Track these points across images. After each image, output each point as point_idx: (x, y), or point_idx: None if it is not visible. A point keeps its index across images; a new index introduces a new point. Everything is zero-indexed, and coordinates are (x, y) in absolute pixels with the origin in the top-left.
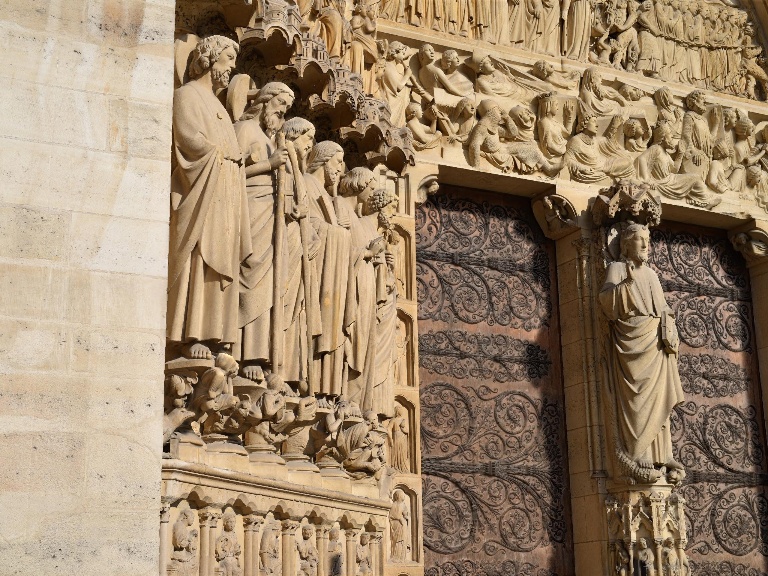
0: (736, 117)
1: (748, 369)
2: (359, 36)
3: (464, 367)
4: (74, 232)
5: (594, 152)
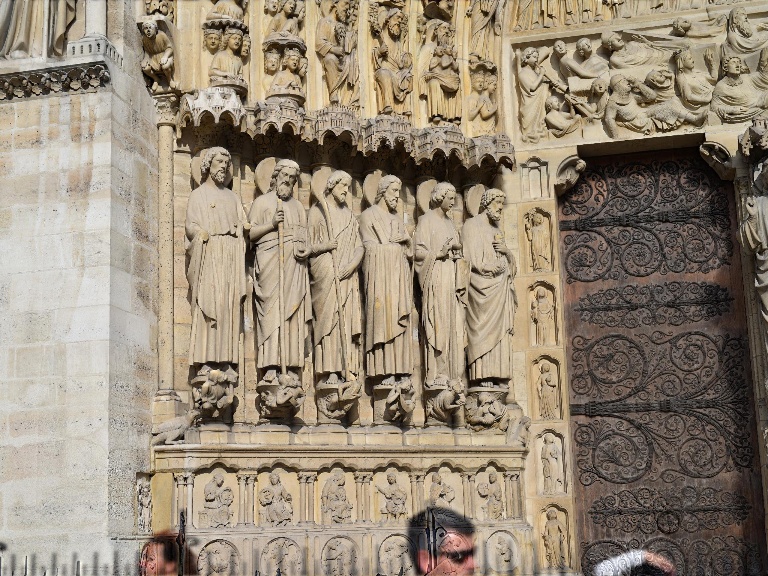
0: None
1: None
2: (435, 74)
3: (636, 317)
4: (57, 322)
5: (742, 91)
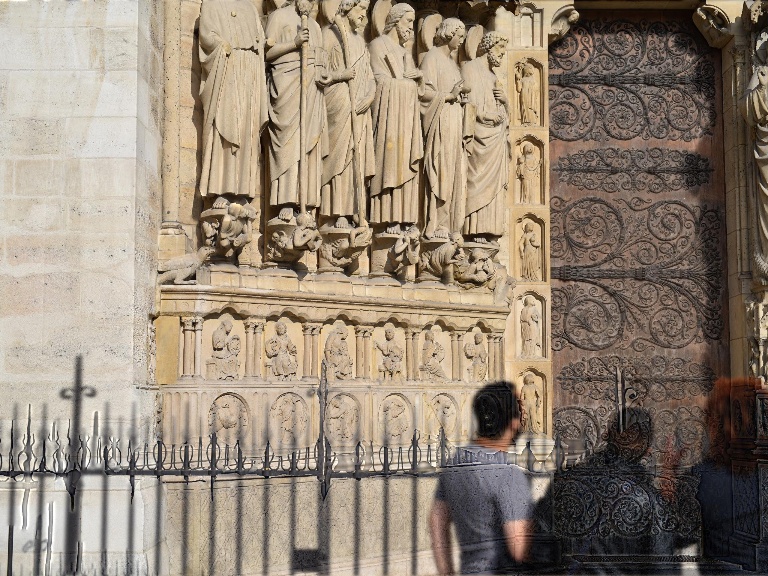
0: None
1: None
2: None
3: (616, 181)
4: (68, 132)
5: None
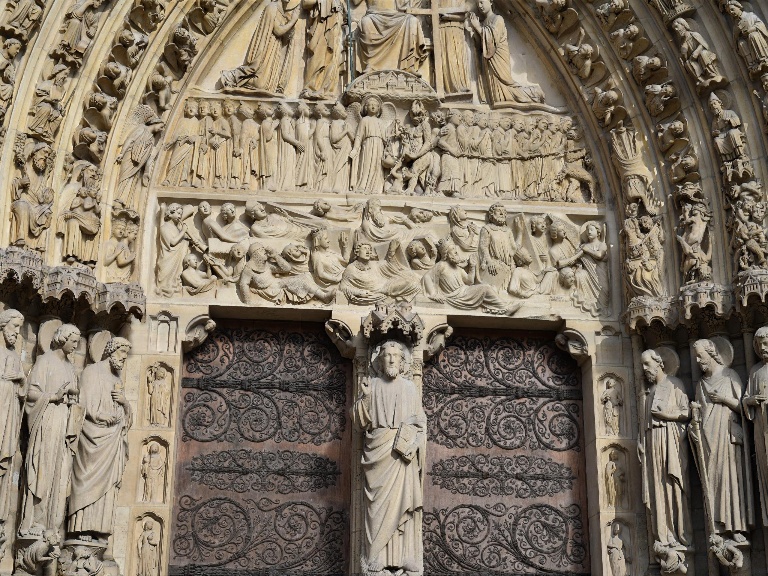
0: (549, 222)
1: (574, 467)
2: (75, 214)
3: (246, 482)
4: None
5: (369, 276)
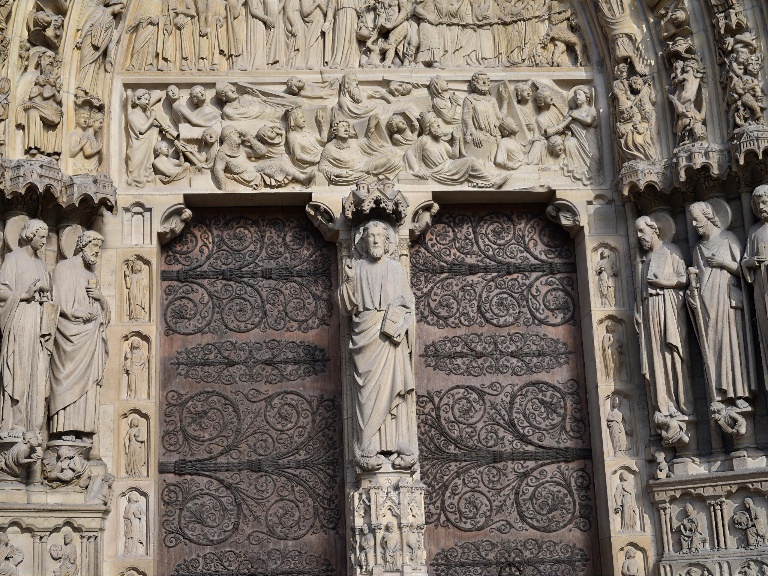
0: (534, 89)
1: (570, 342)
2: (34, 104)
3: (233, 374)
4: None
5: (349, 155)
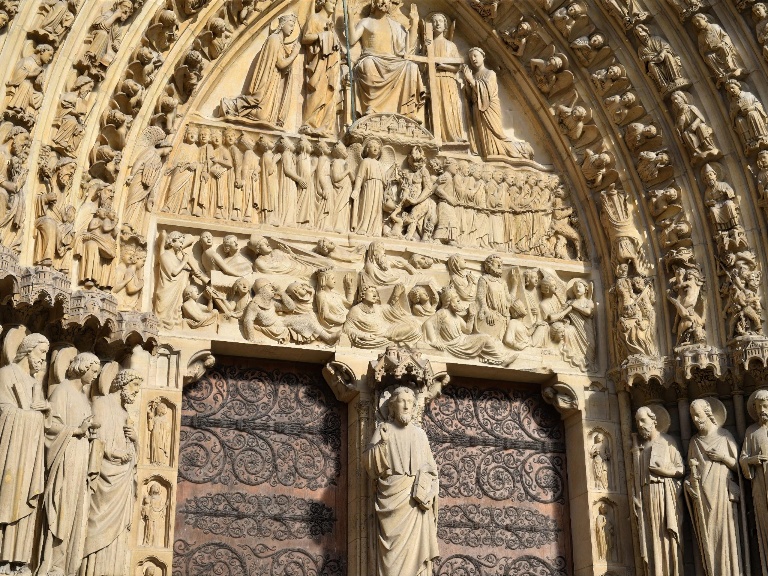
0: (540, 276)
1: (559, 520)
2: (94, 236)
3: (242, 527)
4: None
5: (374, 320)
